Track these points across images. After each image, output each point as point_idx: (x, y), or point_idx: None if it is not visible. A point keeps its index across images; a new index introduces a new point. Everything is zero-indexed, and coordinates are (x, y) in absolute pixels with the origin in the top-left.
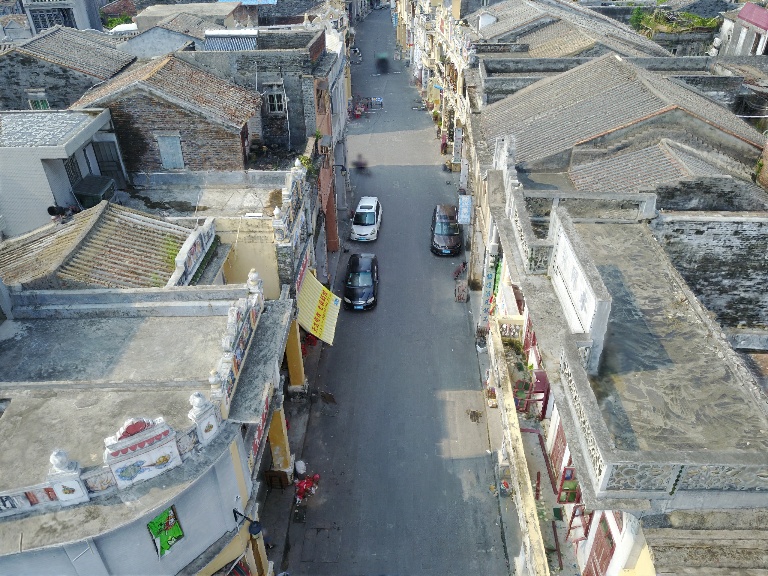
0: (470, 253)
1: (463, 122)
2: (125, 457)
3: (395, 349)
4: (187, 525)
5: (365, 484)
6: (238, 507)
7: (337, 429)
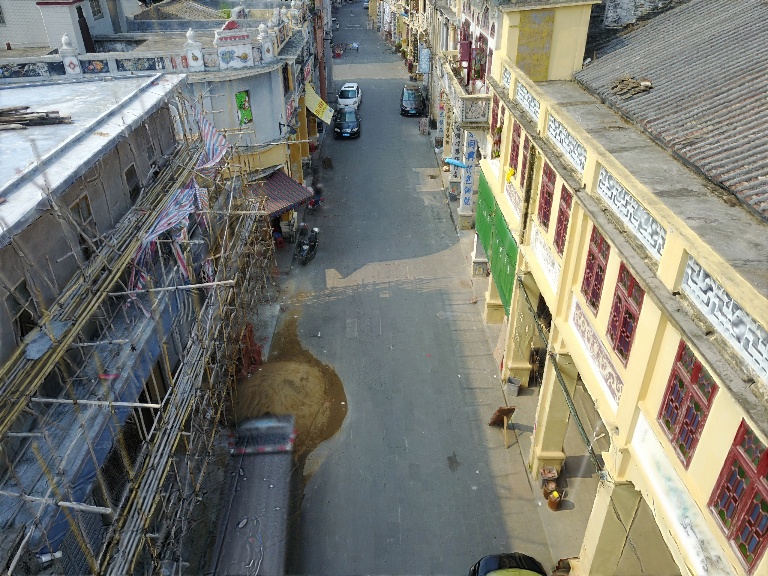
0: (430, 98)
1: (424, 29)
2: (226, 43)
3: (374, 153)
4: (255, 113)
5: (356, 201)
6: (282, 123)
7: (334, 183)
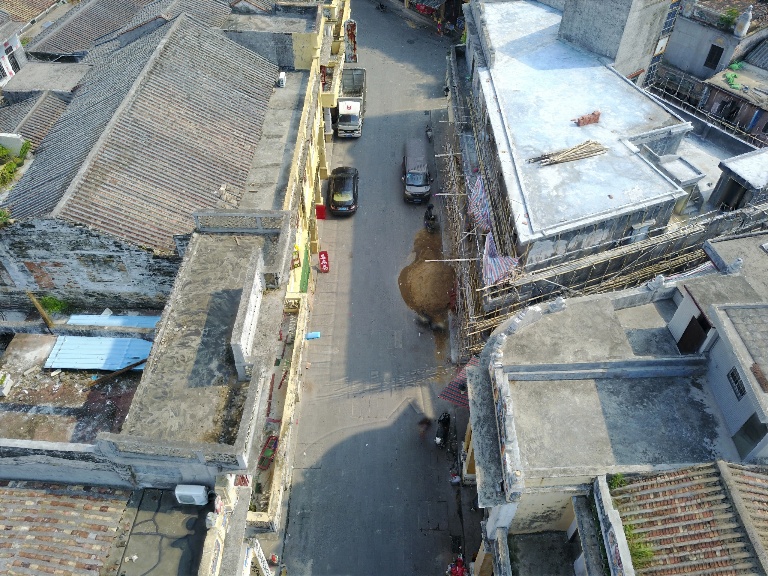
0: None
1: None
2: None
3: None
4: None
5: None
6: None
7: None
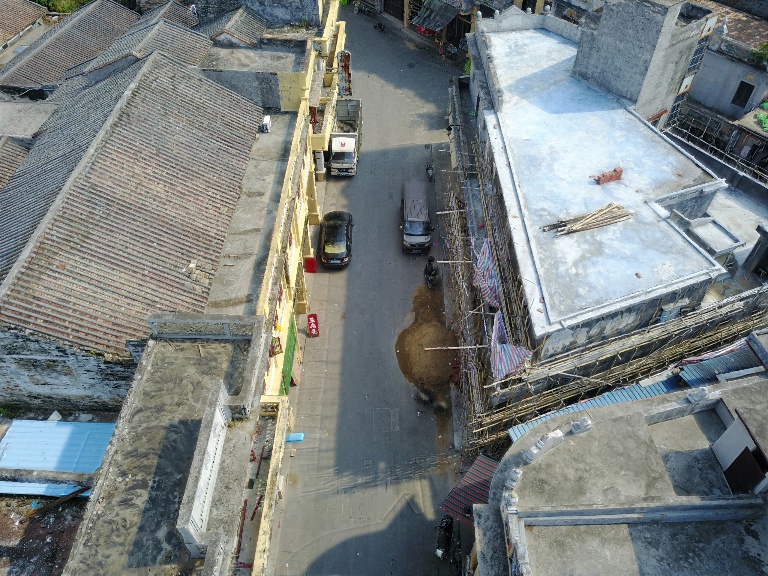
0: None
1: None
2: None
3: None
4: None
5: None
6: None
7: None
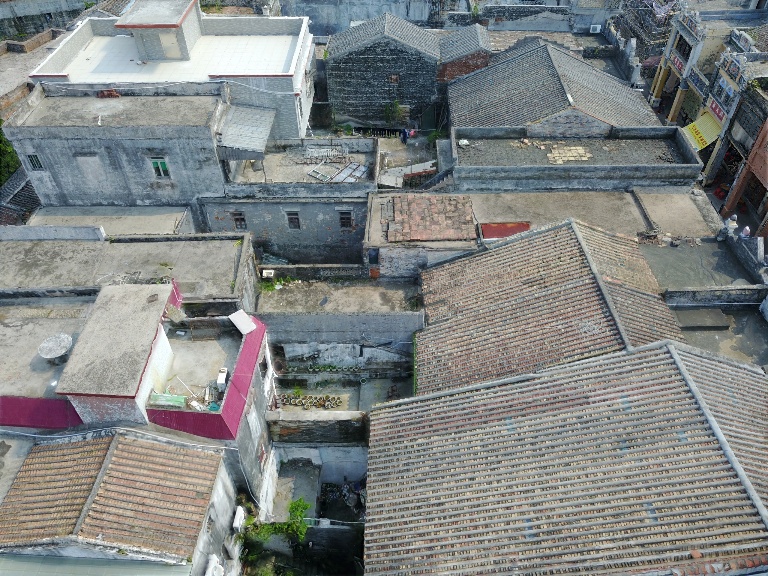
0: None
1: None
2: None
3: None
4: None
5: None
6: None
7: None
